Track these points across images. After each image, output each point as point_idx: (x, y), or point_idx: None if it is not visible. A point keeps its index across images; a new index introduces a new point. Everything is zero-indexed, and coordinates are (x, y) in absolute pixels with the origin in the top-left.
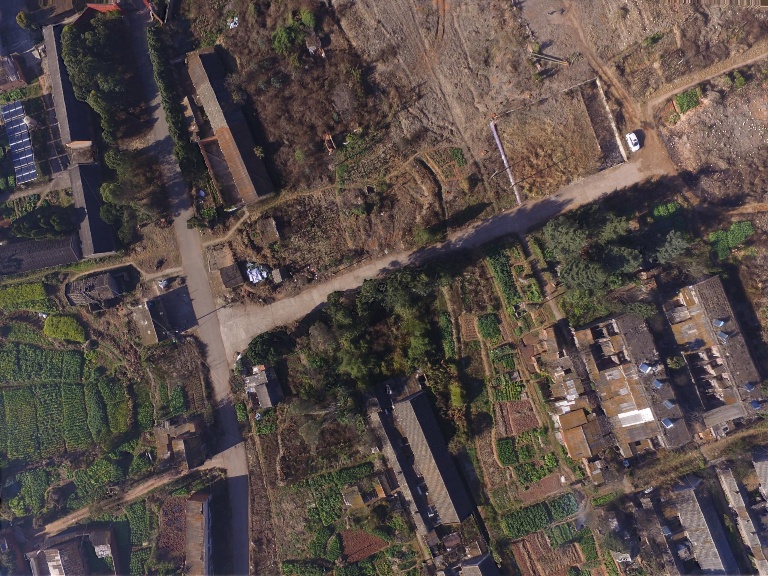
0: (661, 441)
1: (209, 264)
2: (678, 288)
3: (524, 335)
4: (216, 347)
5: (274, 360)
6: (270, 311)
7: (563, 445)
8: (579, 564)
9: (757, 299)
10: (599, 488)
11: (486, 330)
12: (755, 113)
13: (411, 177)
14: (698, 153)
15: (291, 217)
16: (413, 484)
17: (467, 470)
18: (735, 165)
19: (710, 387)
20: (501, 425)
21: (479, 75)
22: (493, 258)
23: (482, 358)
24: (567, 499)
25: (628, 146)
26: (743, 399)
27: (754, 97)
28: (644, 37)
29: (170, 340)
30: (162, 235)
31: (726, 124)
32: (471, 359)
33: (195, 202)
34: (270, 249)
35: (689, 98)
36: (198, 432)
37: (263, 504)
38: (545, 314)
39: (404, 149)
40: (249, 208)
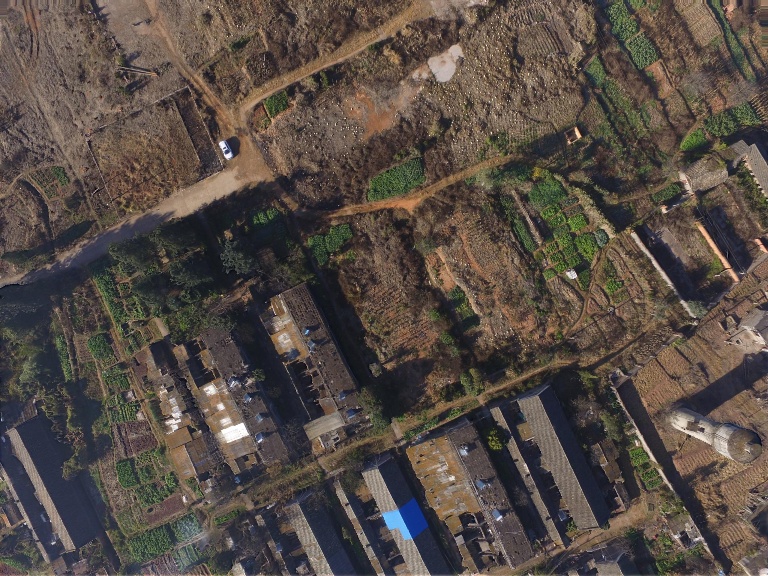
0: None
1: None
2: (268, 297)
3: (136, 353)
4: None
5: None
6: None
7: None
8: None
9: (359, 304)
10: (221, 506)
11: (96, 351)
12: (347, 112)
13: (17, 199)
14: (288, 157)
15: None
16: (35, 512)
17: (92, 495)
18: (329, 167)
19: (319, 397)
20: (120, 447)
21: (74, 91)
22: (97, 277)
23: (99, 379)
24: (188, 519)
25: (223, 154)
26: (340, 408)
27: (345, 96)
28: (229, 42)
29: None
30: None
31: (317, 126)
32: (87, 381)
33: None
34: None
35: (277, 102)
36: None
37: None
38: (151, 331)
39: (8, 171)
40: None
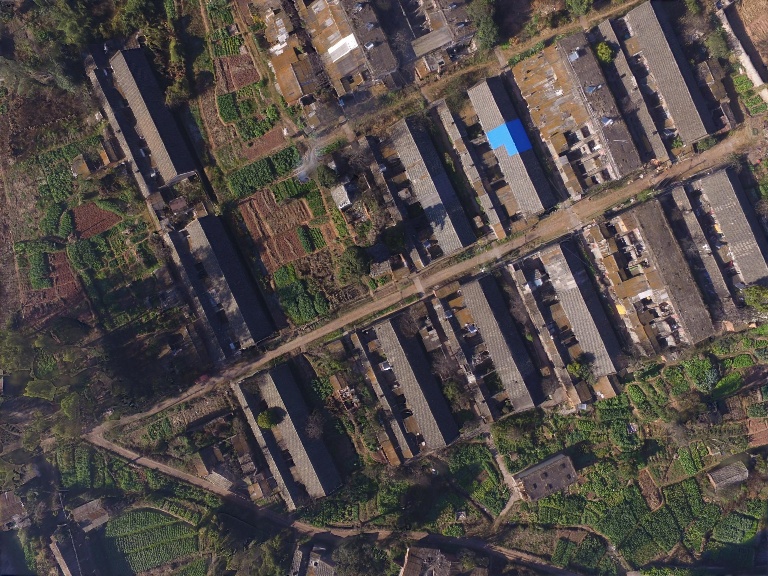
0: None
1: None
2: None
3: None
4: None
5: None
6: None
7: None
8: (307, 221)
9: None
10: (322, 138)
11: None
12: None
13: None
14: None
15: None
16: (135, 145)
17: (192, 132)
18: None
19: None
20: (222, 81)
21: None
22: None
23: (202, 16)
24: (289, 151)
25: None
26: (449, 21)
27: None
28: None
29: None
30: None
31: None
32: (190, 17)
33: None
34: None
35: None
36: None
37: None
38: None
39: None
40: None
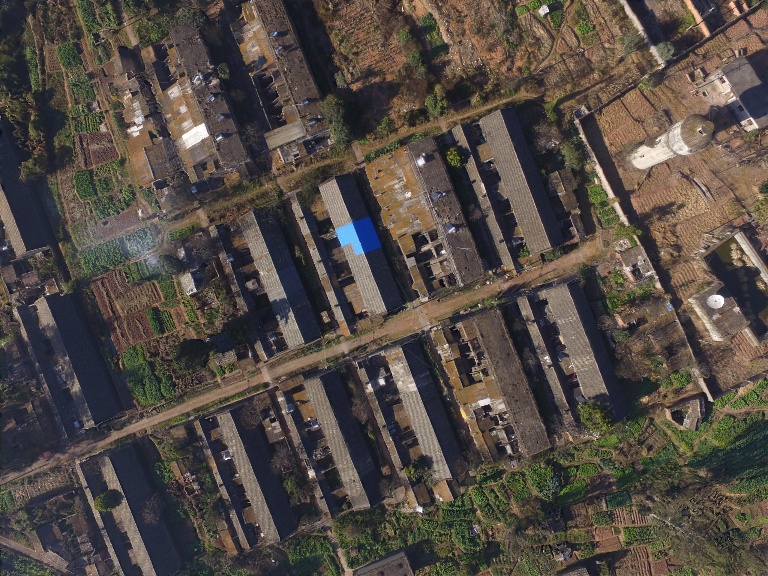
0: None
1: None
2: (240, 3)
3: (104, 64)
4: None
5: None
6: None
7: None
8: (158, 303)
9: (330, 22)
10: (176, 222)
11: (65, 58)
12: None
13: None
14: None
15: None
16: None
17: (48, 206)
18: None
19: None
20: (80, 157)
21: None
22: None
23: (65, 90)
24: (142, 232)
25: None
26: (302, 116)
27: None
28: None
29: None
30: None
31: None
32: (54, 91)
33: None
34: None
35: None
36: None
37: None
38: (121, 40)
39: None
40: None
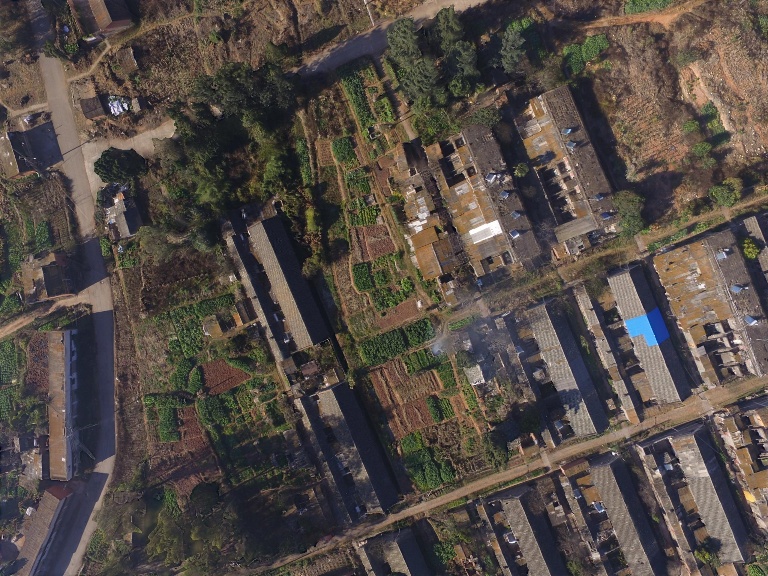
0: (512, 257)
1: (73, 99)
2: (527, 99)
3: (379, 158)
4: (81, 183)
5: (134, 191)
6: (132, 144)
7: (418, 268)
8: (437, 392)
9: (612, 113)
10: (456, 312)
11: (340, 153)
12: None
13: (267, 2)
14: None
15: (150, 47)
16: (269, 310)
17: (325, 298)
18: None
19: (565, 205)
20: (357, 250)
21: None
22: (346, 79)
23: (338, 183)
24: (423, 323)
25: None
26: (594, 211)
27: None
28: None
29: (35, 175)
30: (28, 71)
31: None
32: (327, 184)
33: (59, 37)
34: (131, 81)
35: None
36: (60, 264)
37: (128, 339)
38: (398, 134)
39: None
40: (110, 40)
